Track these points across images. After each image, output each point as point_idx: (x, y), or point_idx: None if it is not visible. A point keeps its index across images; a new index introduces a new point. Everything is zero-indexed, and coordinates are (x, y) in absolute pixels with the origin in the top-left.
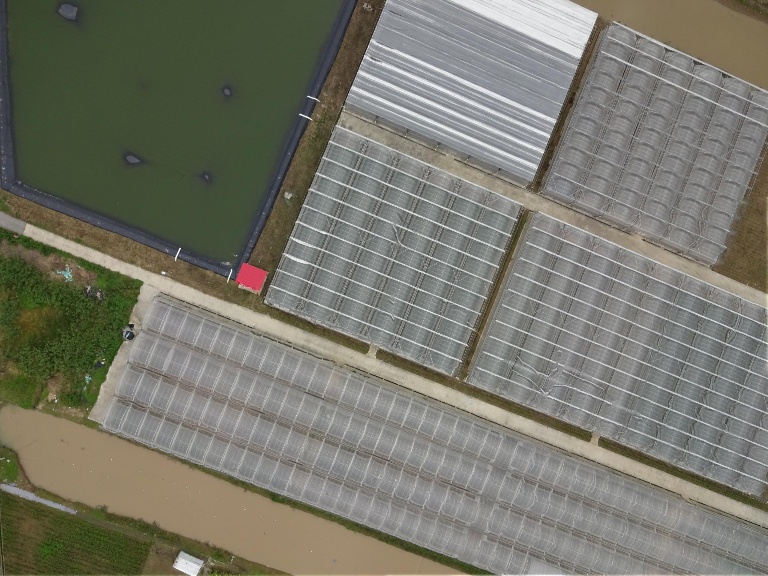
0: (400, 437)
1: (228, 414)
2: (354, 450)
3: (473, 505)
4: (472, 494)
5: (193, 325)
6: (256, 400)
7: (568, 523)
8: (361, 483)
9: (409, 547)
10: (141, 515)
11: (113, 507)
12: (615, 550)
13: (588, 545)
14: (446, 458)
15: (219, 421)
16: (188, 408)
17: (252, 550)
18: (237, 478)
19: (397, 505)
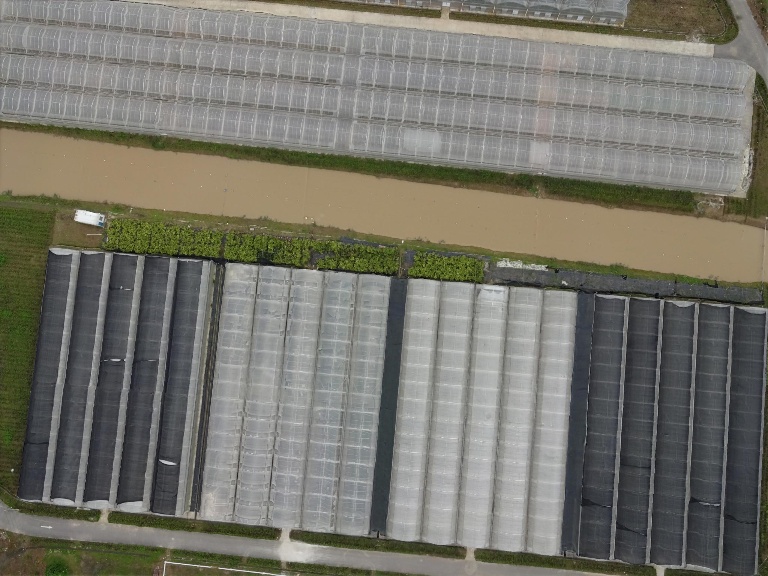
0: (250, 52)
1: (89, 70)
2: (210, 74)
3: (333, 92)
4: (332, 86)
5: (39, 1)
6: (109, 50)
7: (432, 86)
8: (225, 103)
9: (291, 159)
10: (42, 191)
11: (16, 190)
12: (488, 102)
13: (459, 103)
14: (296, 55)
15: (84, 82)
16: (53, 75)
17: (147, 199)
18: (117, 135)
19: (262, 112)
